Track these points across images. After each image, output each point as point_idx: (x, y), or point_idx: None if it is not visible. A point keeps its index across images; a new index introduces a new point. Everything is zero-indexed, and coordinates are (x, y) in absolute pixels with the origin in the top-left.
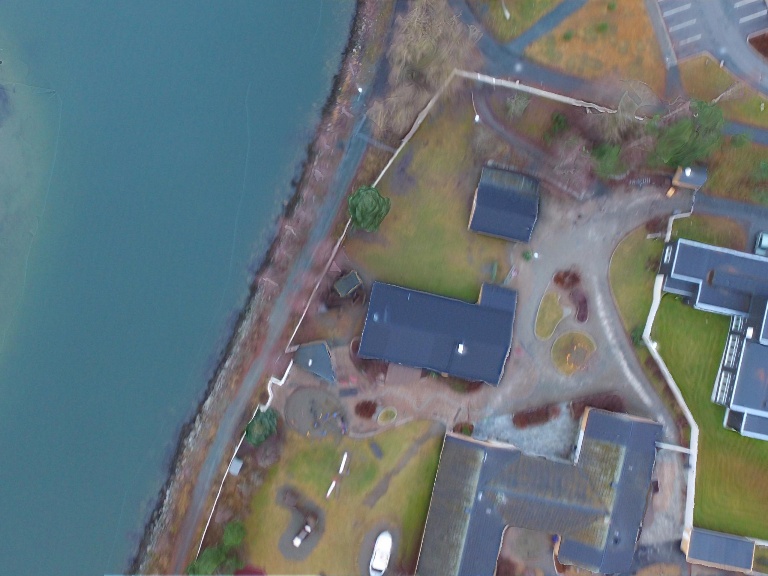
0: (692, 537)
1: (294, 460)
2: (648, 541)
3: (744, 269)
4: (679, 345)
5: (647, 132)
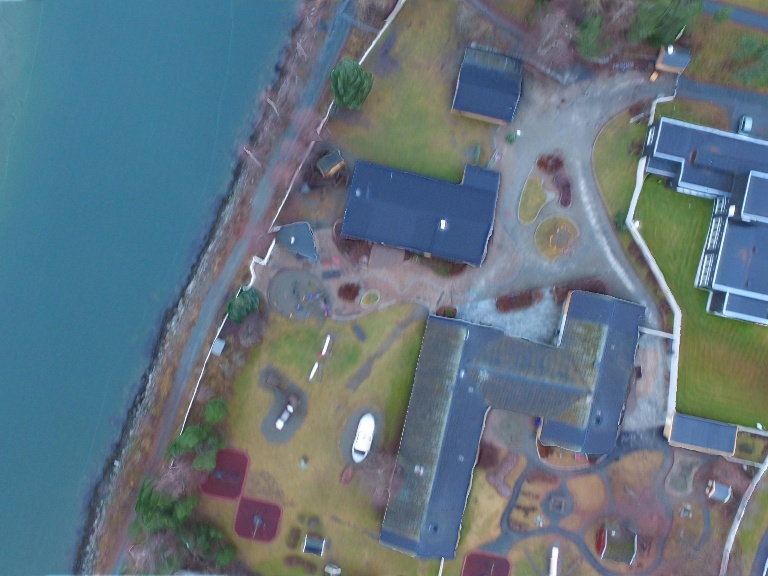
0: (675, 421)
1: (277, 342)
2: (631, 427)
3: (727, 150)
4: (662, 230)
5: None
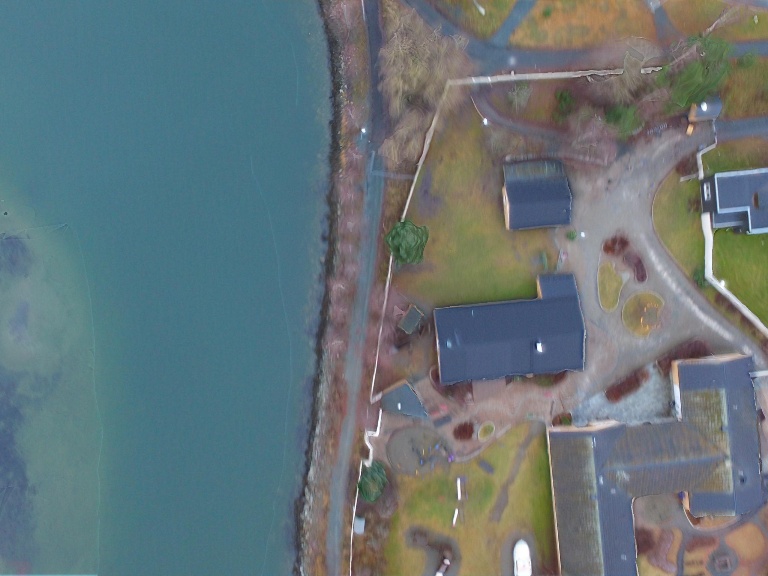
0: None
1: (412, 501)
2: None
3: None
4: (743, 274)
5: (659, 85)
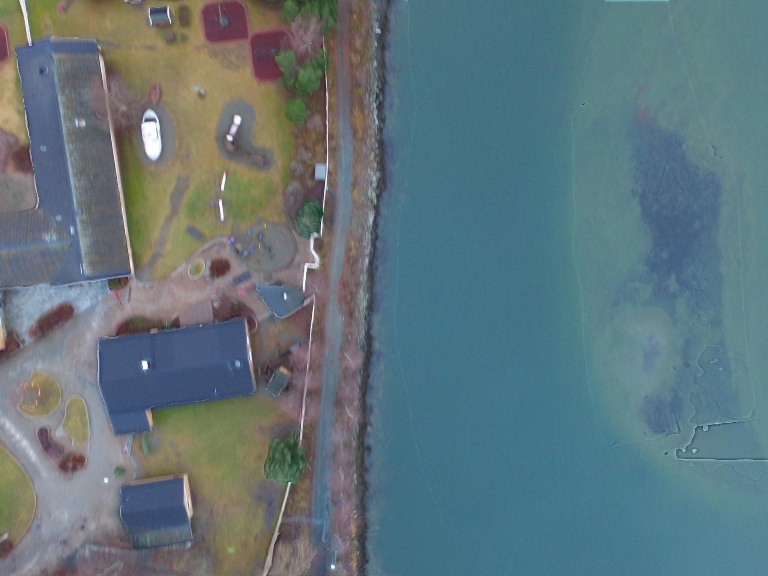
0: None
1: (270, 196)
2: None
3: None
4: None
5: None
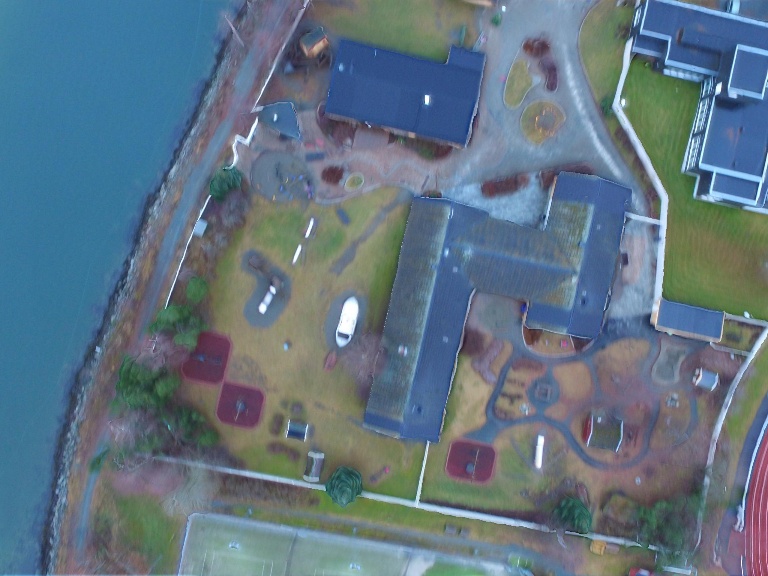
0: (661, 306)
1: (260, 225)
2: (617, 314)
3: (714, 29)
4: (649, 114)
5: None
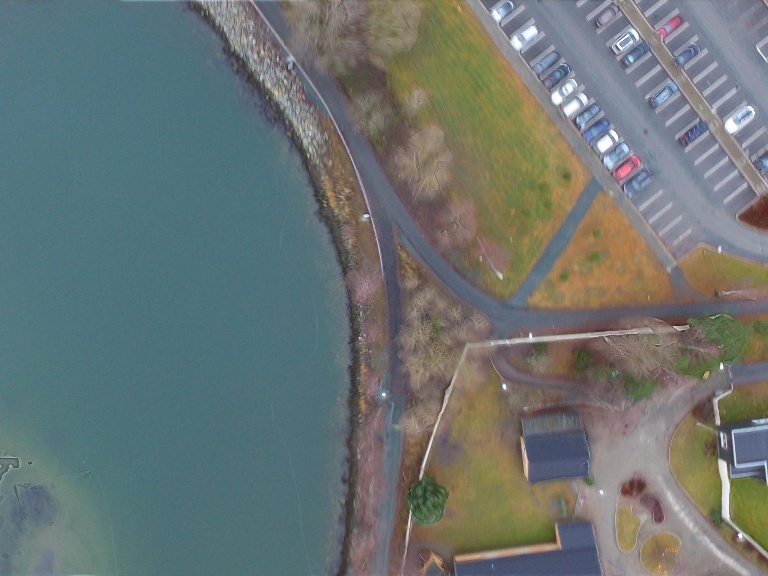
0: None
1: None
2: None
3: None
4: (759, 514)
5: (678, 372)
